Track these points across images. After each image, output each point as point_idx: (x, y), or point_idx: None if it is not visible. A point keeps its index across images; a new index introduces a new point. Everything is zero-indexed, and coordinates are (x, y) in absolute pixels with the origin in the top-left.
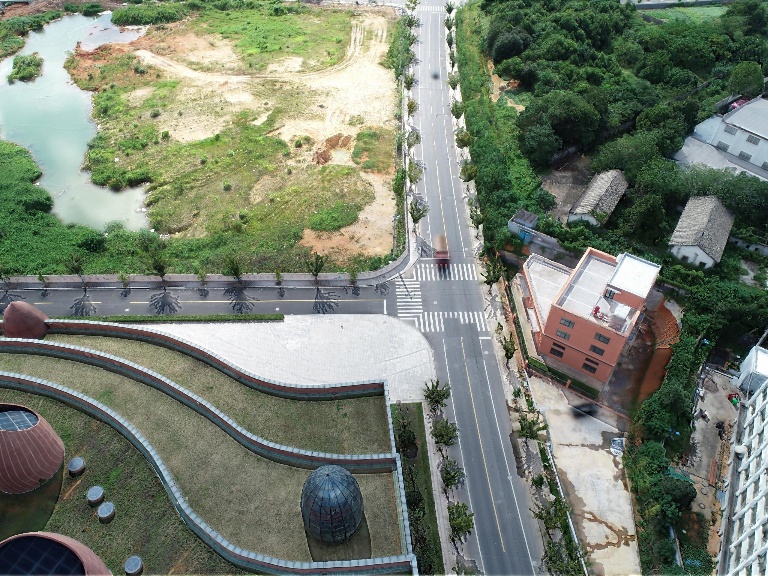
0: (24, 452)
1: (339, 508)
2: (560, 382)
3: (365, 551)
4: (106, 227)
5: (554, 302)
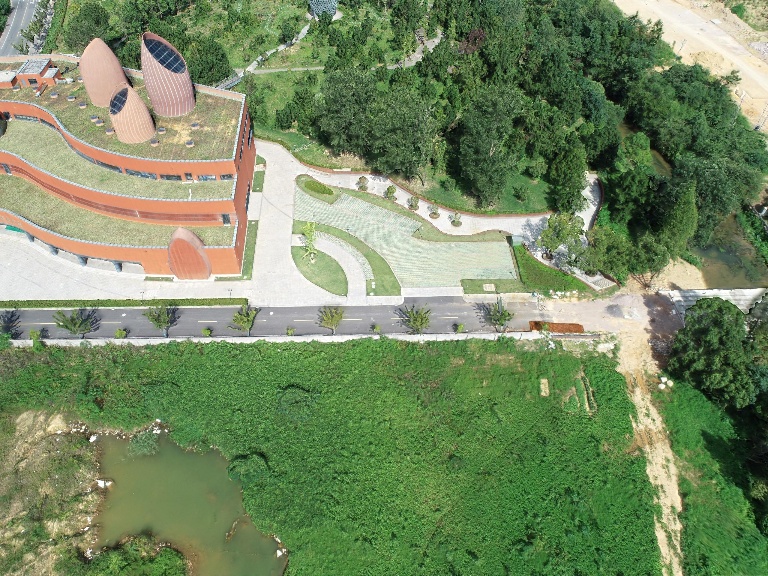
0: None
1: None
2: None
3: None
4: (154, 440)
5: None
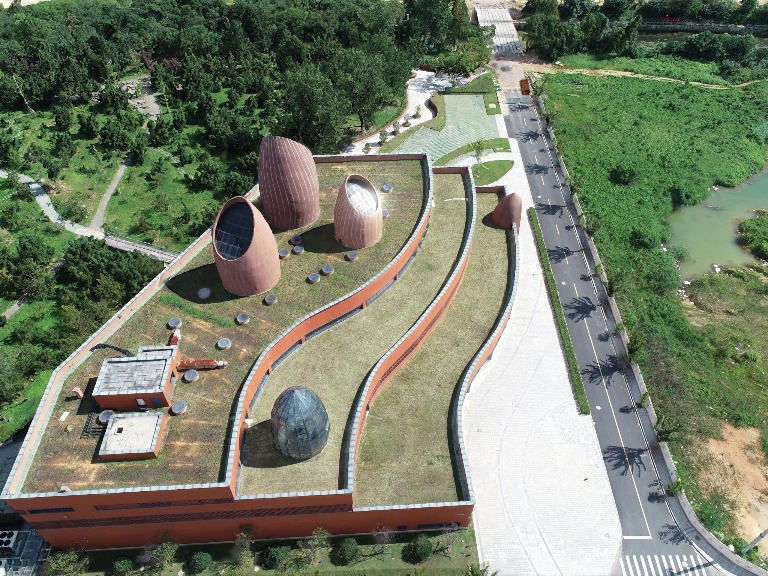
0: (343, 215)
1: (275, 413)
2: None
3: (264, 463)
4: (675, 247)
5: None
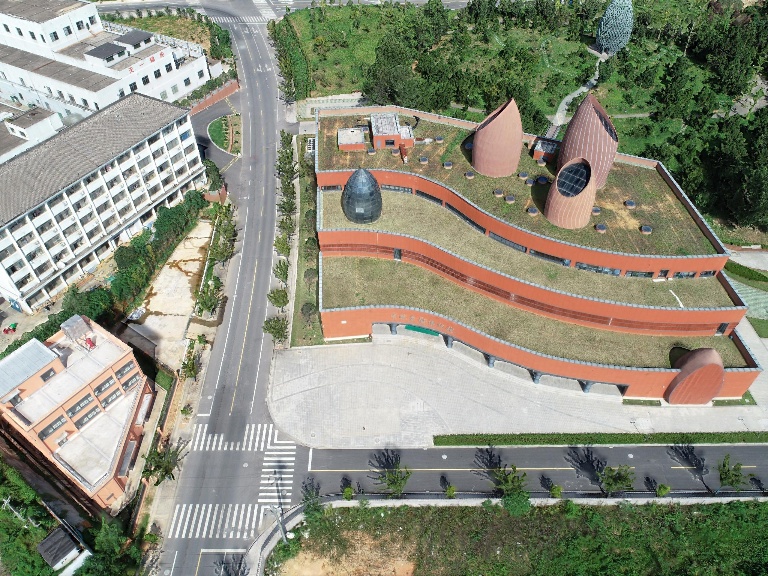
0: None
1: None
2: None
3: None
4: None
5: (128, 351)
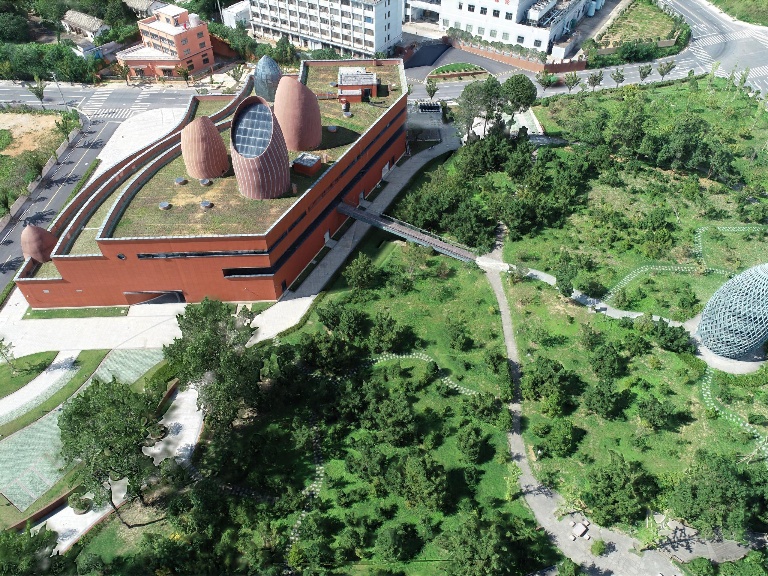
0: None
1: None
2: (209, 72)
3: None
4: None
5: (173, 35)
